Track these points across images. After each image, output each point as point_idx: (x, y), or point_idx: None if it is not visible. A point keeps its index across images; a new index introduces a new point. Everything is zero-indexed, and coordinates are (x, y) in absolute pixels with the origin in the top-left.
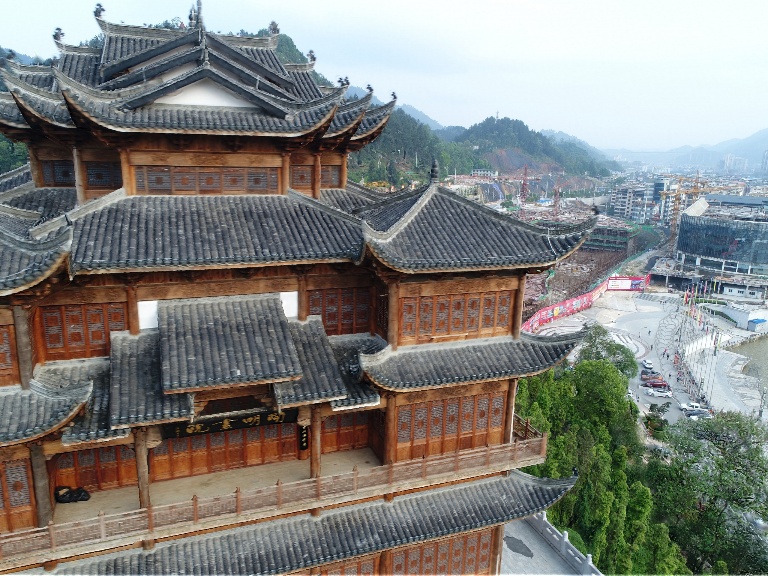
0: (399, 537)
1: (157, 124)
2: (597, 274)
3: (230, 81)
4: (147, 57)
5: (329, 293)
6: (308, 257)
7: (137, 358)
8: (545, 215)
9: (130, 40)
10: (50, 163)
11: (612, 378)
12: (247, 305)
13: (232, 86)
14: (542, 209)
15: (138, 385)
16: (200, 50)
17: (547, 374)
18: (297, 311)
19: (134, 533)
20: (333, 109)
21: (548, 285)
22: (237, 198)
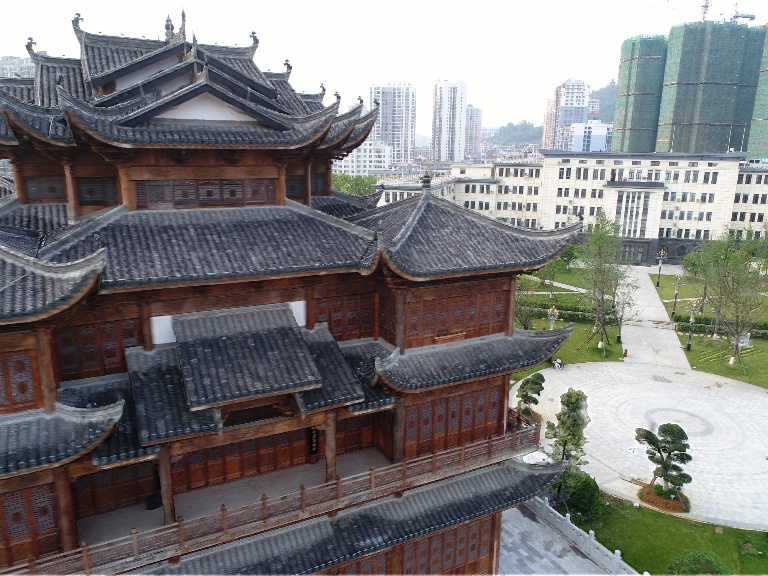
0: None
1: None
2: None
3: None
4: None
5: None
6: None
7: None
8: None
9: None
10: None
11: None
12: None
13: None
14: None
15: None
16: None
17: None
18: None
19: None
20: None
21: None
22: None
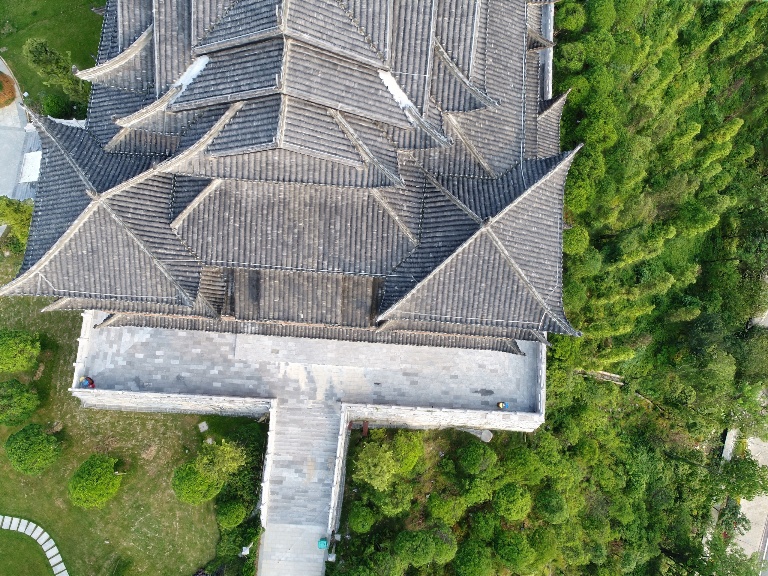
0: (402, 341)
1: None
2: None
3: (302, 153)
4: None
5: None
6: None
7: (249, 273)
8: None
9: None
10: None
11: None
12: None
13: None
14: None
15: (249, 295)
16: (279, 93)
17: None
18: None
19: (257, 322)
20: None
21: None
22: None
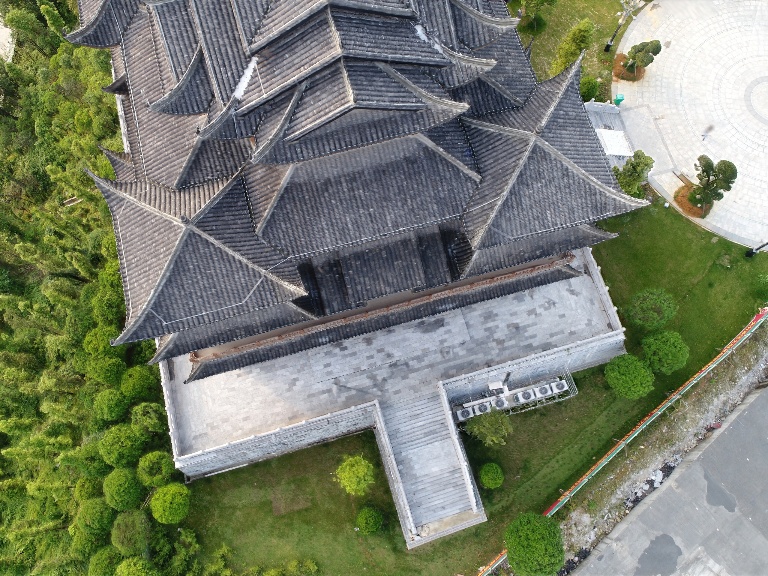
0: None
1: None
2: None
3: None
4: None
5: None
6: None
7: None
8: None
9: None
10: None
11: None
12: None
13: None
14: None
15: None
16: None
17: None
18: None
19: None
20: None
21: None
22: None
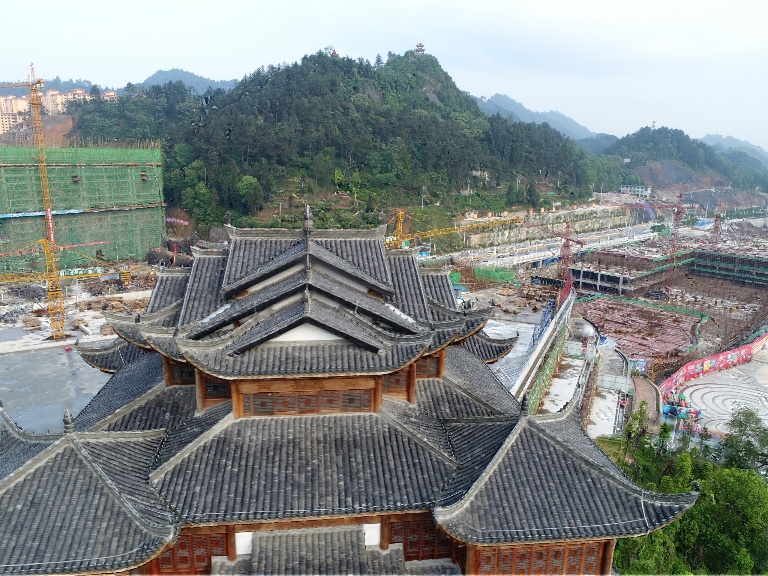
0: None
1: (260, 372)
2: (762, 317)
3: (327, 325)
4: (261, 279)
5: (411, 524)
6: (388, 509)
7: None
8: (702, 242)
9: (252, 244)
10: (179, 365)
11: (758, 494)
12: (331, 539)
13: (329, 329)
14: (699, 236)
15: None
16: (305, 284)
17: (682, 468)
18: (379, 540)
19: None
20: (423, 350)
21: (699, 331)
22: (332, 419)
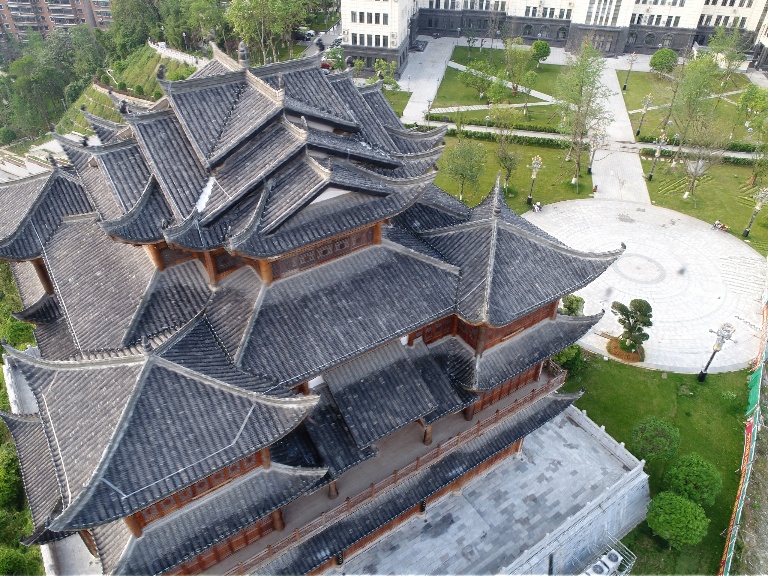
0: None
1: None
2: None
3: None
4: None
5: None
6: None
7: None
8: None
9: None
10: None
11: None
12: None
13: None
14: None
15: None
16: None
17: None
18: None
19: None
20: None
21: None
22: None
